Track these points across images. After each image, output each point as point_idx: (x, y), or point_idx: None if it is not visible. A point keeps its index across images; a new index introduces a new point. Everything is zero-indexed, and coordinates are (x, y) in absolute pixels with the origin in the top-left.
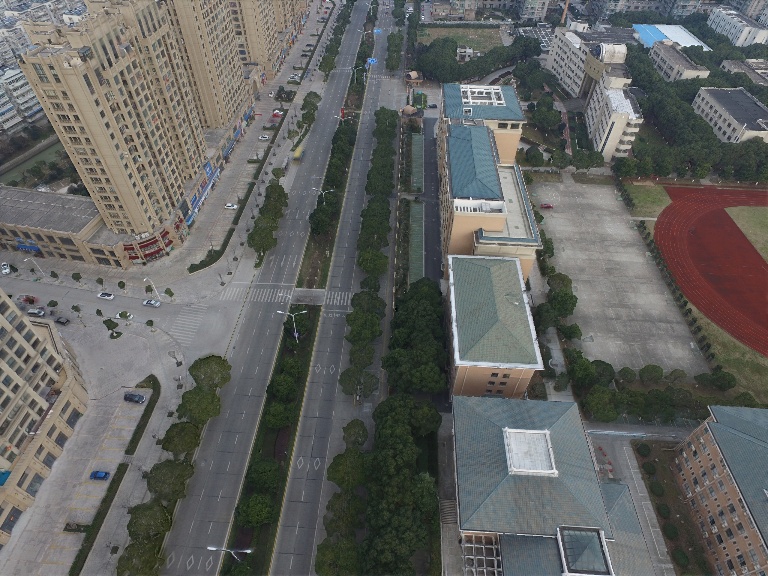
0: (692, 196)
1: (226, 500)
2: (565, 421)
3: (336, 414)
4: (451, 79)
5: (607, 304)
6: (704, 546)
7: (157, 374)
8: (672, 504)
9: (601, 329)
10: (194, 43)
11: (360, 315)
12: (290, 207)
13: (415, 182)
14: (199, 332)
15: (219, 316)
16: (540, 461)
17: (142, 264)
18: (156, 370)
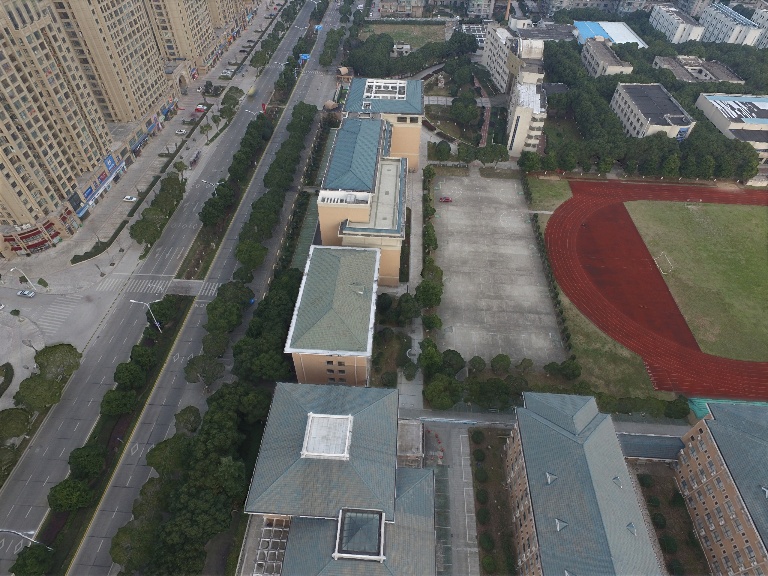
0: (594, 190)
1: (51, 485)
2: (378, 407)
3: (183, 402)
4: (380, 75)
5: (481, 295)
6: (513, 531)
7: (14, 363)
8: (493, 490)
9: (468, 320)
10: (94, 36)
11: (219, 305)
12: (190, 200)
13: (321, 176)
14: (67, 322)
15: (91, 306)
16: (335, 445)
17: (26, 255)
18: (14, 359)
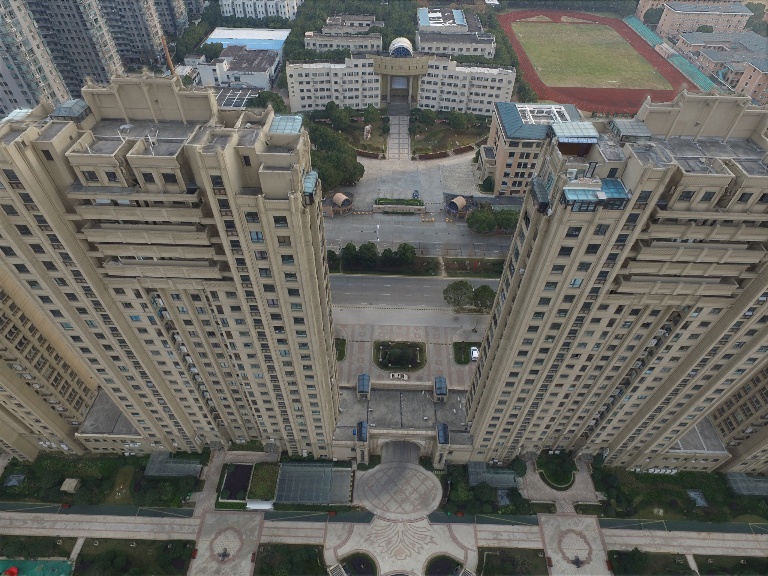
0: (539, 93)
1: None
2: None
3: None
4: None
5: None
6: None
7: None
8: None
9: None
10: None
11: None
12: None
13: None
14: None
15: None
16: None
17: None
18: None
